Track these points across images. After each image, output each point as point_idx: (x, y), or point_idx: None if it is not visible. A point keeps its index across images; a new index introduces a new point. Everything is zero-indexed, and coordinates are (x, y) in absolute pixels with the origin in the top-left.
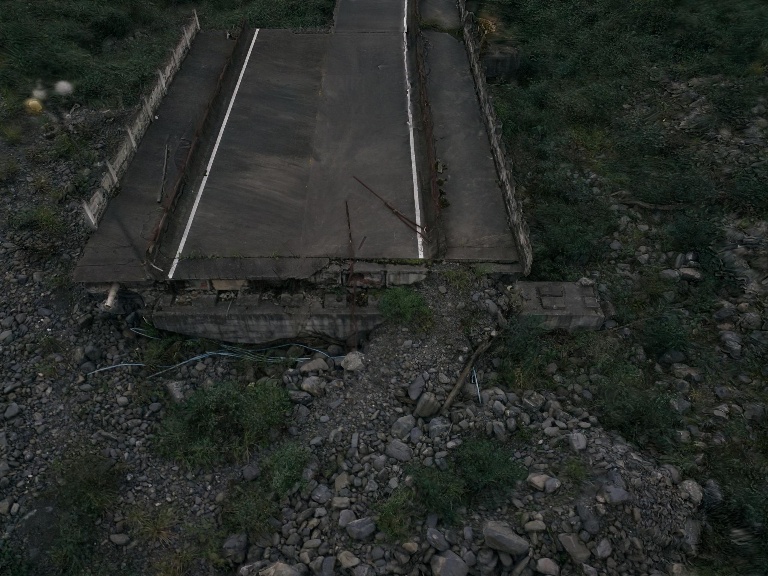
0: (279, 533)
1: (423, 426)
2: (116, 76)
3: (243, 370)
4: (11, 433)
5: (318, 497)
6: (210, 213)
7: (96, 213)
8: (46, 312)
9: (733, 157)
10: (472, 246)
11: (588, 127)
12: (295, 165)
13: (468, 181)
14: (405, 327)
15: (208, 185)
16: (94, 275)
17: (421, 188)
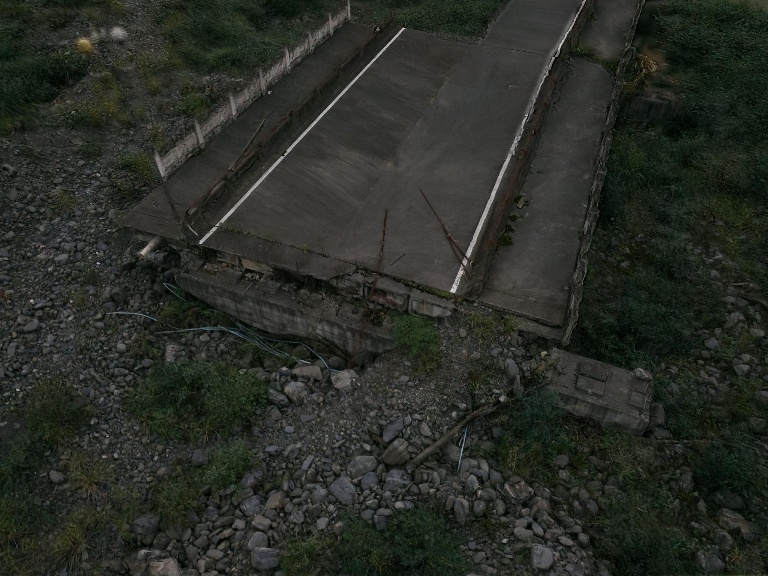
0: (192, 530)
1: (382, 474)
2: (264, 51)
3: (242, 354)
4: (21, 346)
5: (246, 508)
6: (268, 192)
7: (169, 167)
8: (103, 247)
9: None
10: (515, 295)
11: (735, 200)
12: (371, 165)
13: (546, 224)
14: (409, 361)
15: (281, 165)
16: (140, 223)
17: (489, 219)
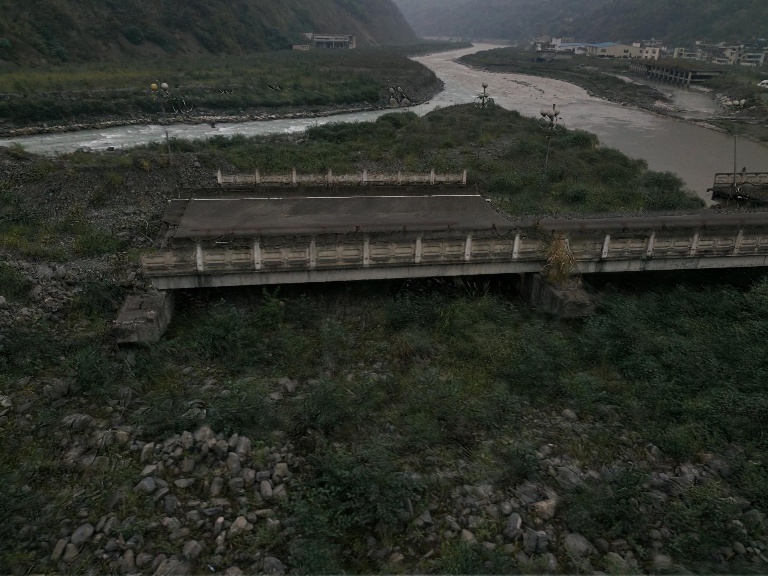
0: None
1: None
2: None
3: None
4: None
5: None
6: None
7: (228, 183)
8: None
9: (477, 507)
10: None
11: (478, 373)
12: None
13: None
14: None
15: None
16: None
17: None
